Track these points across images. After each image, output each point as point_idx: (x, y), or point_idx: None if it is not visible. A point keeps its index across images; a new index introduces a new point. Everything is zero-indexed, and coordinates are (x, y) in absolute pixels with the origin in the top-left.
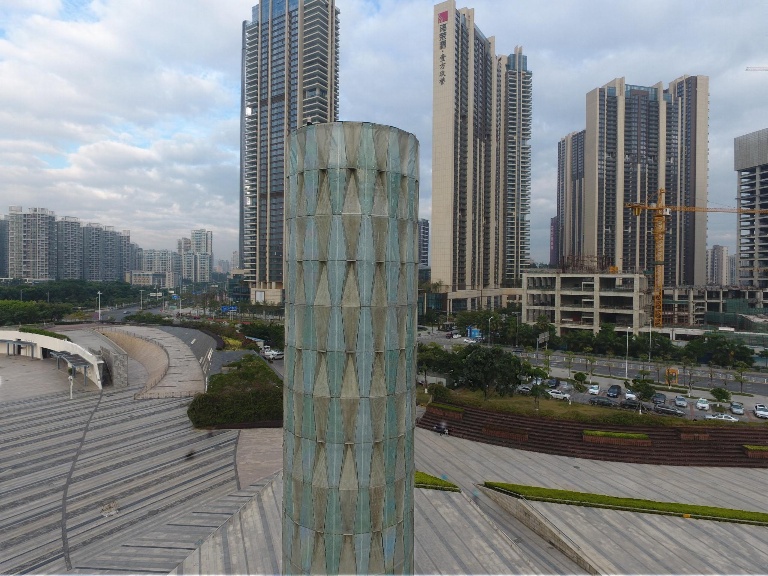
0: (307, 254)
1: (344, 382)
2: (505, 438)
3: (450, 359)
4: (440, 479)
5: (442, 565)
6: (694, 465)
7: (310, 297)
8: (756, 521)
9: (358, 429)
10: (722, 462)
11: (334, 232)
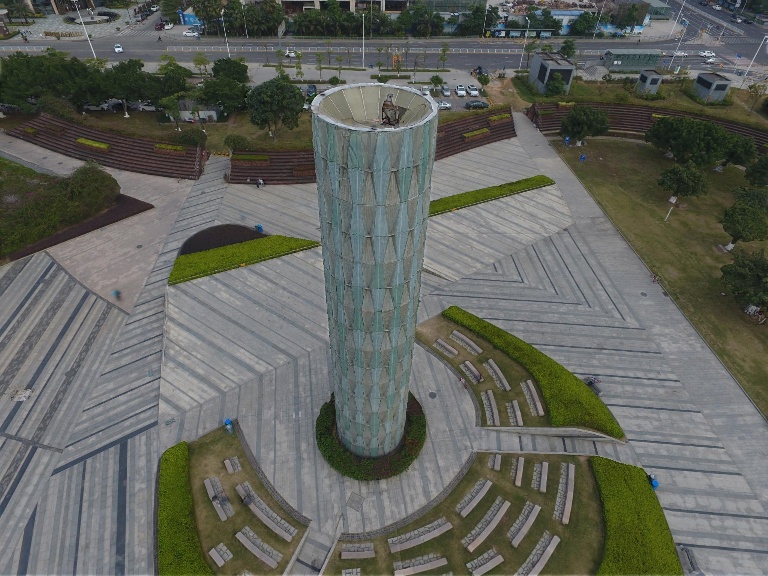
0: (376, 232)
1: (402, 297)
2: (314, 175)
3: (216, 90)
4: (299, 239)
5: None
6: (439, 159)
7: (378, 258)
8: (485, 200)
9: (407, 315)
10: (453, 151)
11: (400, 214)
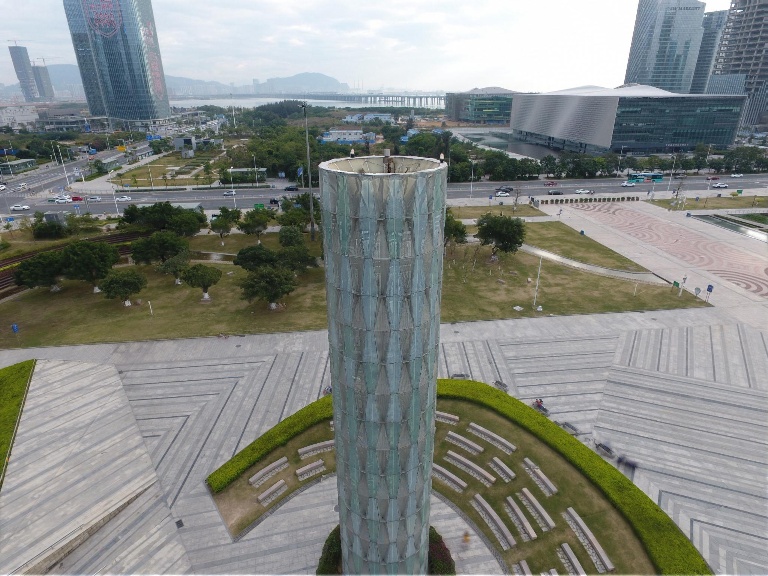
0: None
1: None
2: None
3: None
4: None
5: None
6: None
7: None
8: None
9: None
10: None
11: None
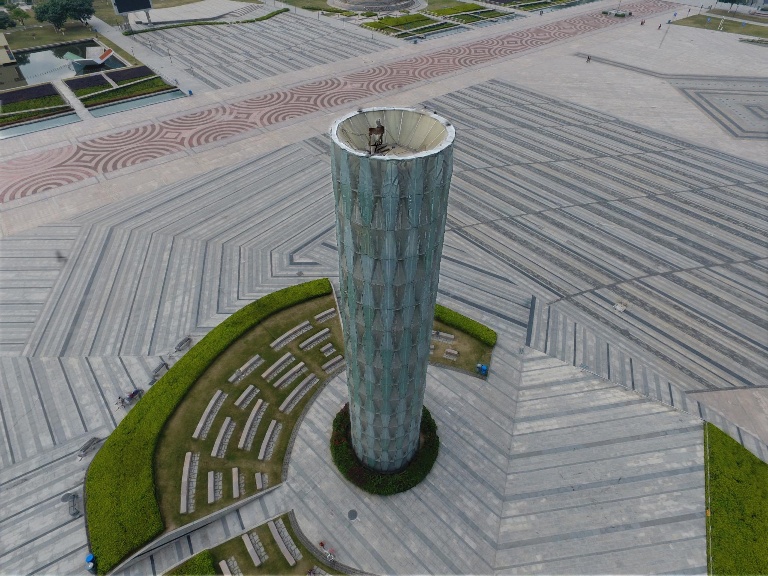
0: None
1: None
2: None
3: None
4: None
5: (550, 569)
6: None
7: None
8: None
9: None
10: None
11: None
